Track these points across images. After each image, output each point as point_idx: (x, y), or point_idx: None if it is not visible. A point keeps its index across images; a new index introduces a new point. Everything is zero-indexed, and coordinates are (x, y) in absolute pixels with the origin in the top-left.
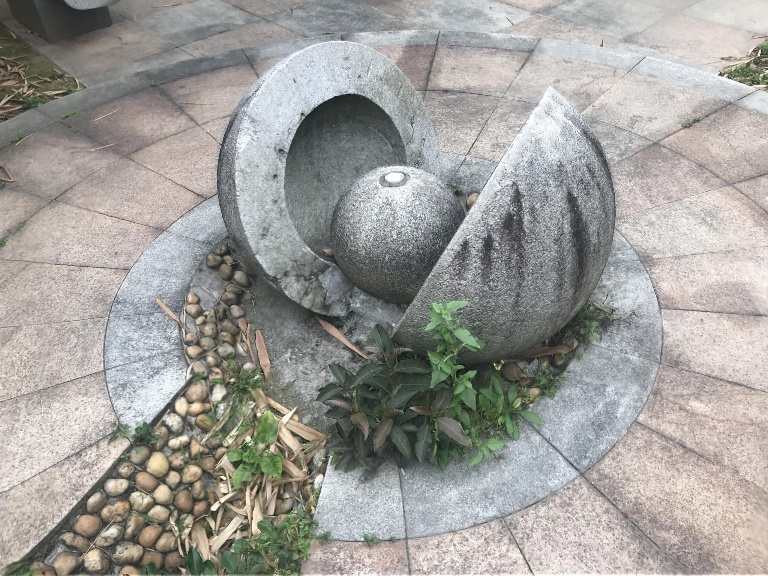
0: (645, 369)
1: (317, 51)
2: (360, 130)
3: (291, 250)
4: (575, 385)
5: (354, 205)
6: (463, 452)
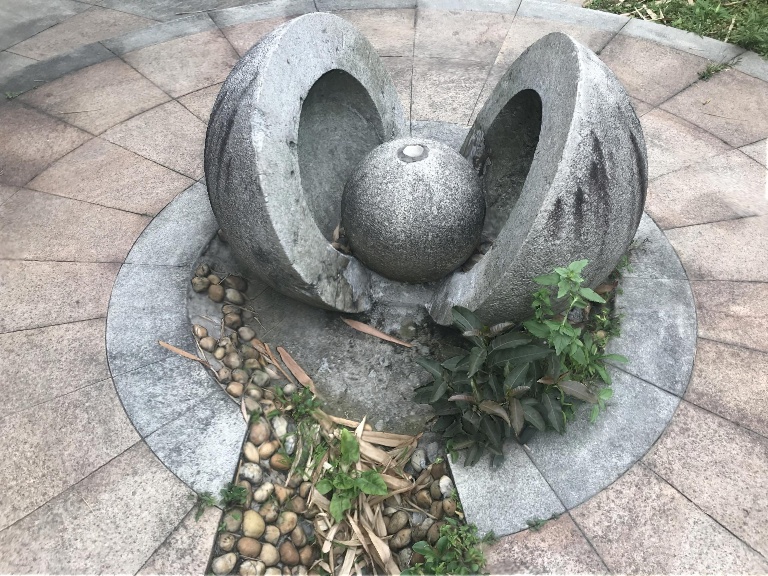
0: (680, 288)
1: (300, 26)
2: (333, 109)
3: (318, 251)
4: (631, 319)
5: (380, 188)
6: (572, 410)
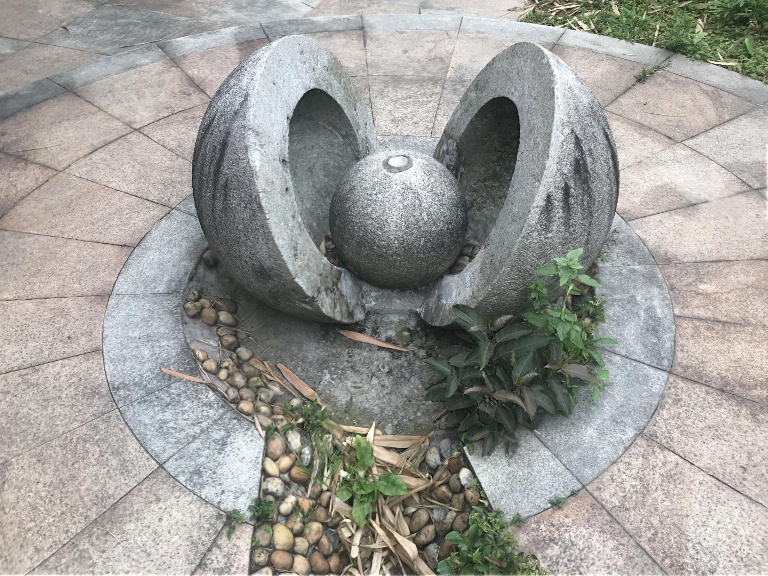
0: (651, 273)
1: (280, 48)
2: (309, 128)
3: (315, 264)
4: (612, 304)
5: (370, 199)
6: (573, 394)
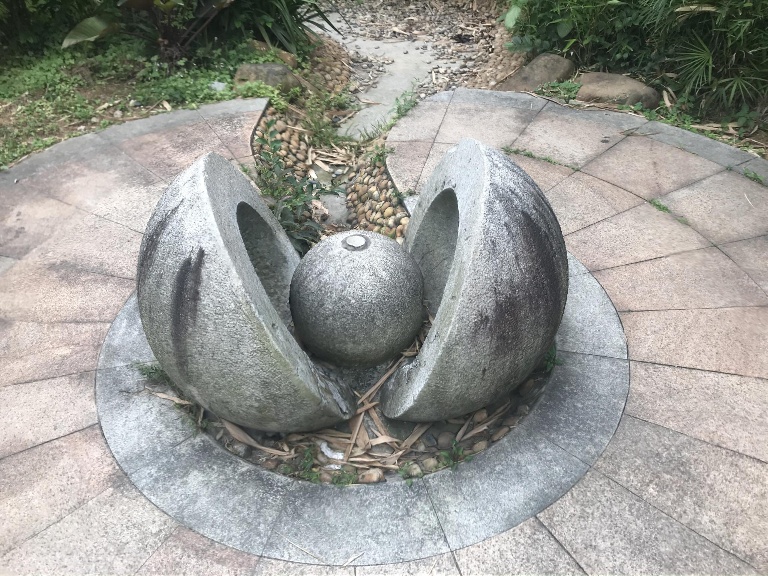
0: (109, 359)
1: None
2: None
3: None
4: None
5: None
6: None
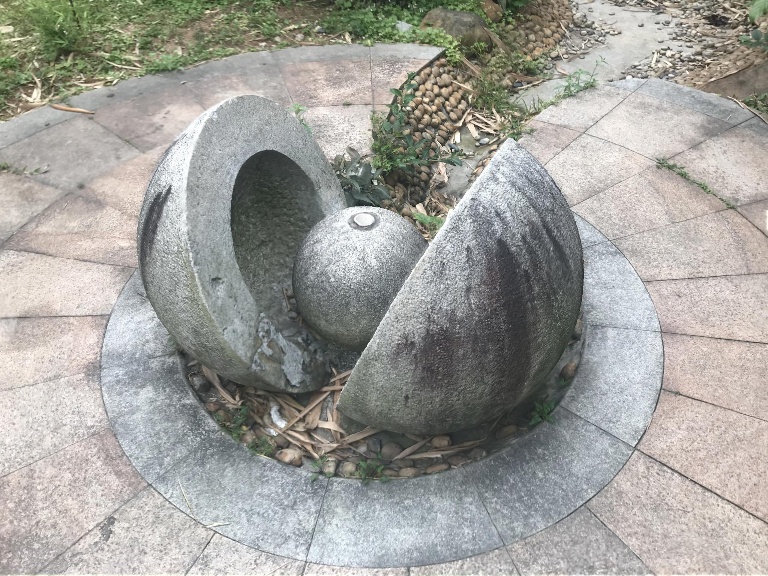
0: None
1: None
2: None
3: None
4: None
5: None
6: None
